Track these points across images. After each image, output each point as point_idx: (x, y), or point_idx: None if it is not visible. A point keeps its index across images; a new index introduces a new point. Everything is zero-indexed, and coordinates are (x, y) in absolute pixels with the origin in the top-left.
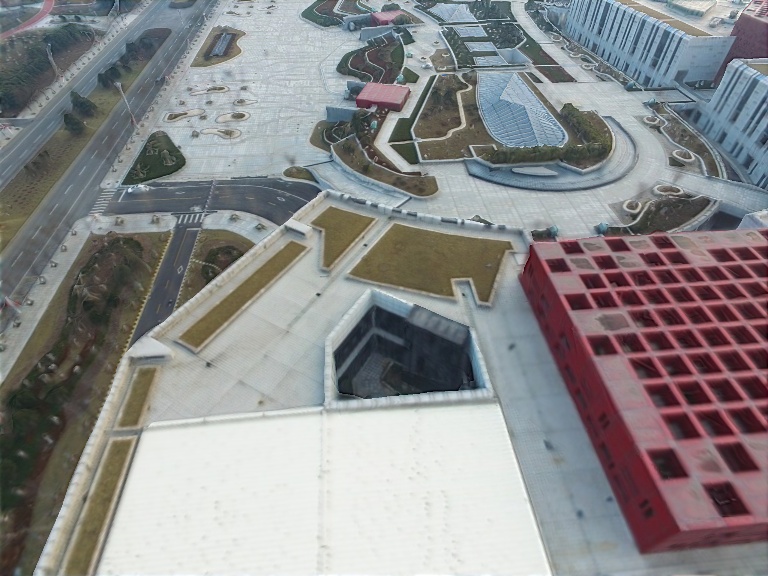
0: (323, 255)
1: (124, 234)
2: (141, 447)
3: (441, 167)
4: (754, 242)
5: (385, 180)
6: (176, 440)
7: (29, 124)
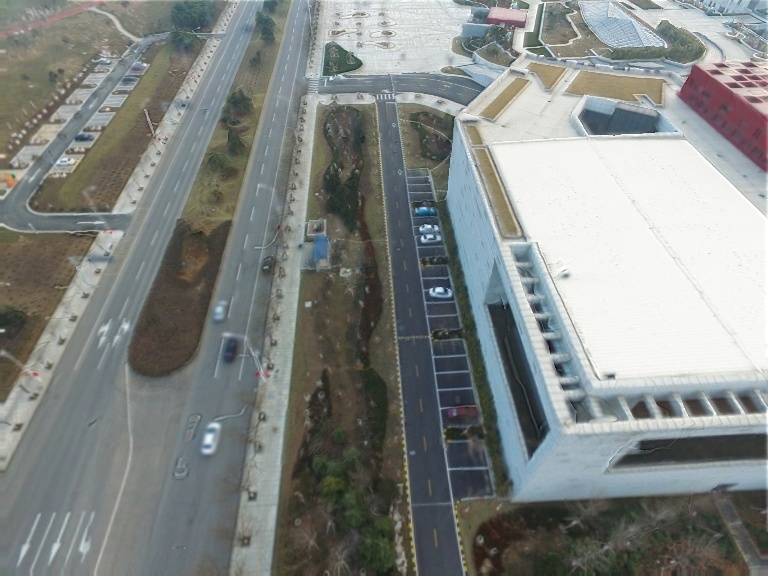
0: (543, 83)
1: (342, 104)
2: (493, 151)
3: None
4: None
5: None
6: (510, 148)
7: (224, 37)
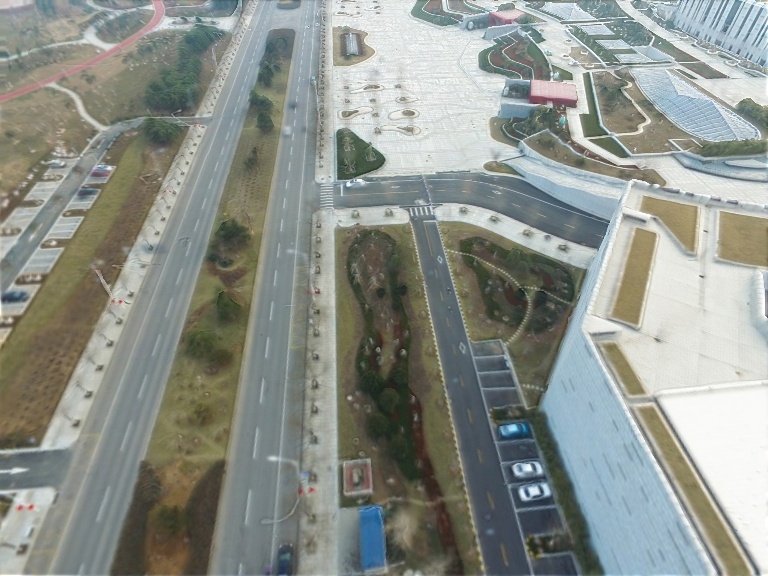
0: (679, 240)
1: (367, 226)
2: (669, 412)
3: (652, 160)
4: None
5: (607, 173)
6: (696, 406)
7: (210, 122)
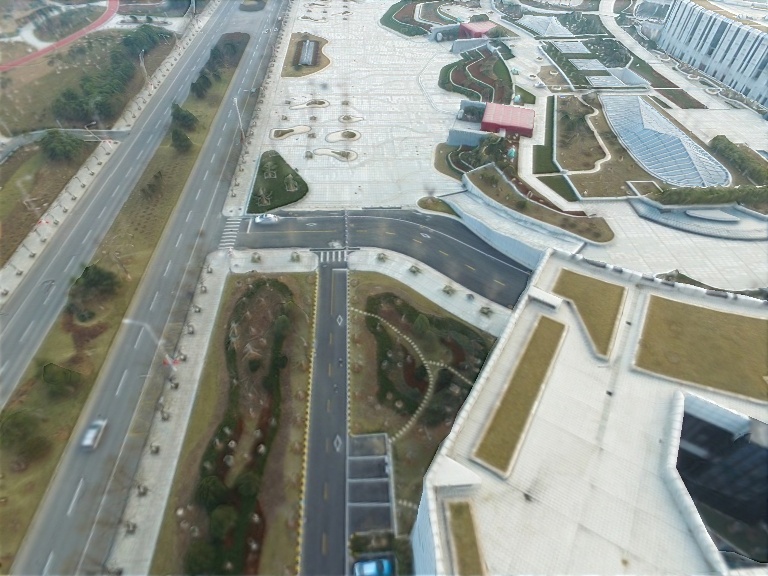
0: (590, 337)
1: (265, 273)
2: None
3: (604, 206)
4: None
5: (549, 220)
6: None
7: (126, 137)
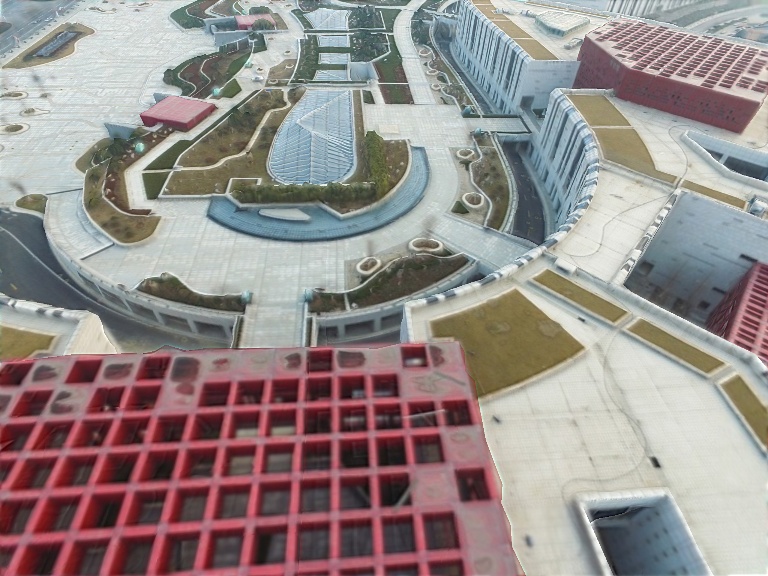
0: None
1: None
2: None
3: (181, 204)
4: (284, 371)
5: (100, 219)
6: None
7: None
